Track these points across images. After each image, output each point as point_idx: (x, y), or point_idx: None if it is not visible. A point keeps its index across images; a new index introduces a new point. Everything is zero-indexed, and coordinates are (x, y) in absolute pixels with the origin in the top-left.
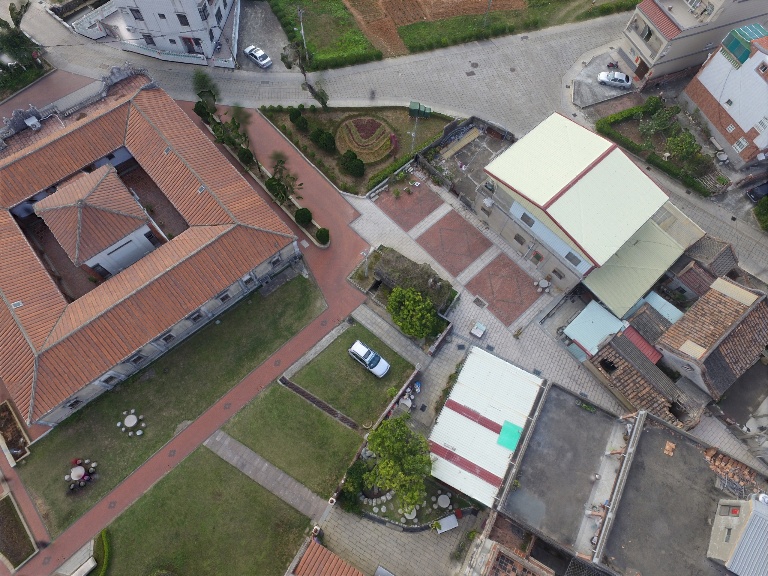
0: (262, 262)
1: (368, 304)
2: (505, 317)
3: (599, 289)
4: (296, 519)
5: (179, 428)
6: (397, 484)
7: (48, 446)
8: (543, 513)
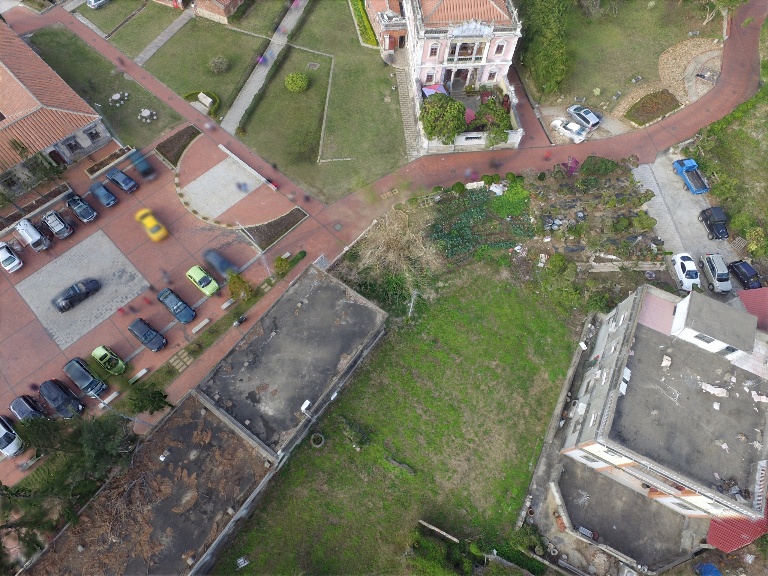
0: (7, 26)
1: (64, 5)
2: None
3: None
4: (191, 24)
5: (128, 78)
6: None
7: (126, 139)
8: None
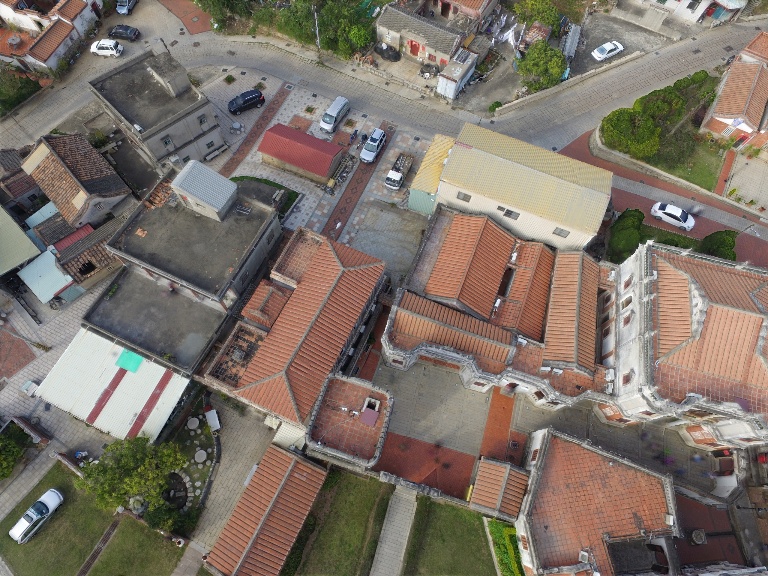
0: None
1: None
2: (24, 360)
3: (3, 267)
4: None
5: None
6: (154, 473)
7: None
8: (197, 336)
